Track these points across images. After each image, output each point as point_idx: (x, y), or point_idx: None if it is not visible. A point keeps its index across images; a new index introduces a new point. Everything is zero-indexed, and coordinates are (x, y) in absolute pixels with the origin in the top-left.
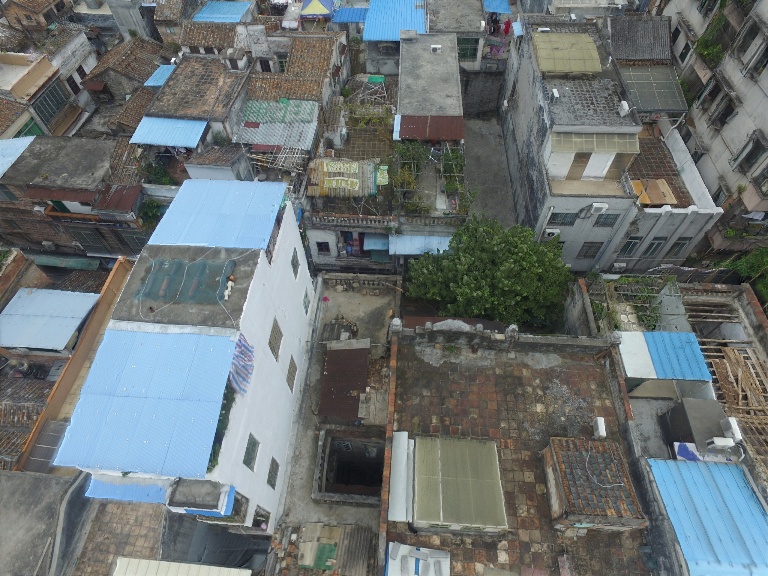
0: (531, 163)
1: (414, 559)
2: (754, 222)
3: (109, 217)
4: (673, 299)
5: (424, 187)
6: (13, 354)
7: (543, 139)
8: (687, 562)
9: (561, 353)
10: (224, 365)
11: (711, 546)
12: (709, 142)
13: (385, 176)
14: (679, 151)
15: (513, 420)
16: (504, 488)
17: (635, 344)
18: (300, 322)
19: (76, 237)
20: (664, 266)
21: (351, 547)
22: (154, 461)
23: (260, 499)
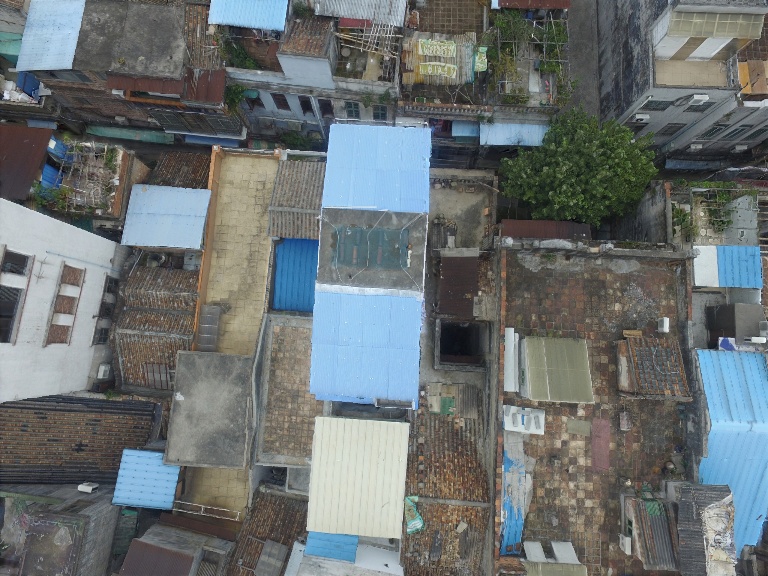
0: (634, 32)
1: (521, 415)
2: None
3: None
4: (749, 211)
5: None
6: (149, 248)
7: (659, 13)
8: (711, 421)
9: (641, 260)
10: (415, 321)
11: (729, 410)
12: None
13: (484, 61)
14: None
15: (596, 317)
16: None
17: (708, 257)
18: None
19: (156, 118)
20: (746, 167)
21: (465, 399)
22: (380, 391)
23: None
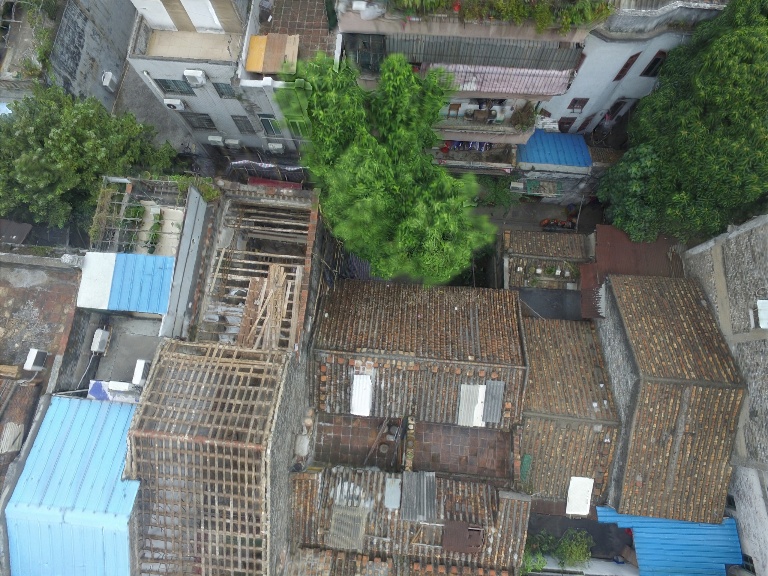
0: None
1: None
2: None
3: None
4: None
5: (25, 32)
6: None
7: None
8: (7, 504)
9: (47, 270)
10: None
11: (44, 489)
12: None
13: None
14: None
15: None
16: None
17: (100, 268)
18: None
19: None
20: None
21: None
22: None
23: None
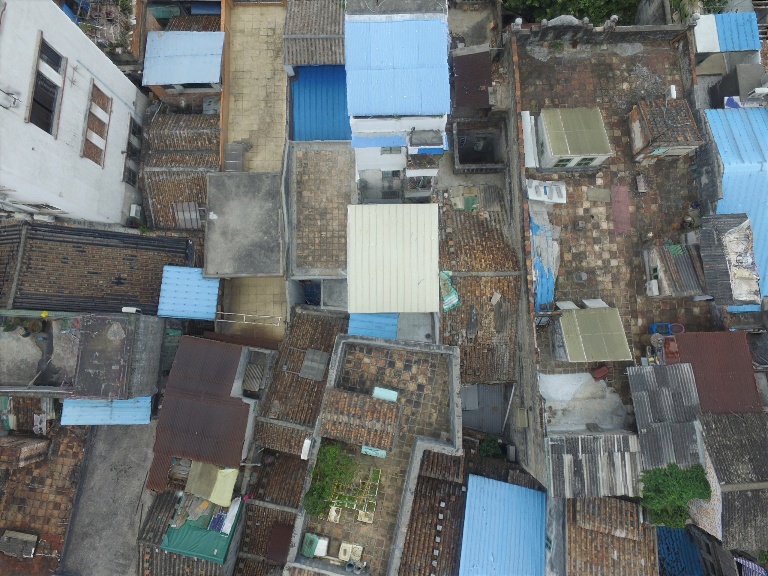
0: None
1: (543, 187)
2: None
3: None
4: None
5: None
6: (168, 94)
7: None
8: (724, 164)
9: (644, 41)
10: (442, 41)
11: (740, 155)
12: None
13: None
14: None
15: (606, 96)
16: None
17: (707, 25)
18: None
19: None
20: None
21: (487, 196)
22: (415, 107)
23: None
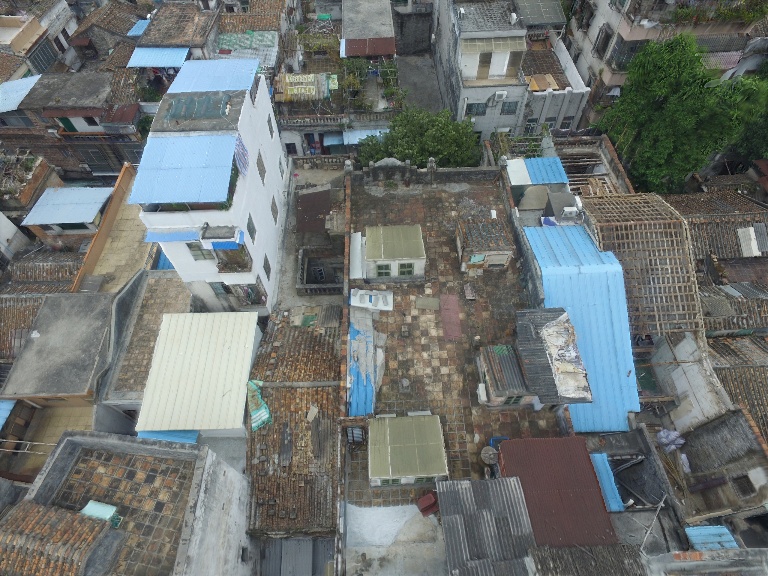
0: (451, 72)
1: (368, 296)
2: (617, 101)
3: (114, 131)
4: (547, 141)
5: (368, 96)
6: (49, 235)
7: (456, 48)
8: (540, 267)
9: (469, 181)
10: (230, 149)
11: (557, 260)
12: (582, 44)
13: (335, 83)
14: (563, 55)
15: (435, 221)
16: (429, 257)
17: (518, 166)
18: (277, 177)
19: (84, 157)
20: None
21: (327, 315)
22: (193, 196)
23: (260, 272)
